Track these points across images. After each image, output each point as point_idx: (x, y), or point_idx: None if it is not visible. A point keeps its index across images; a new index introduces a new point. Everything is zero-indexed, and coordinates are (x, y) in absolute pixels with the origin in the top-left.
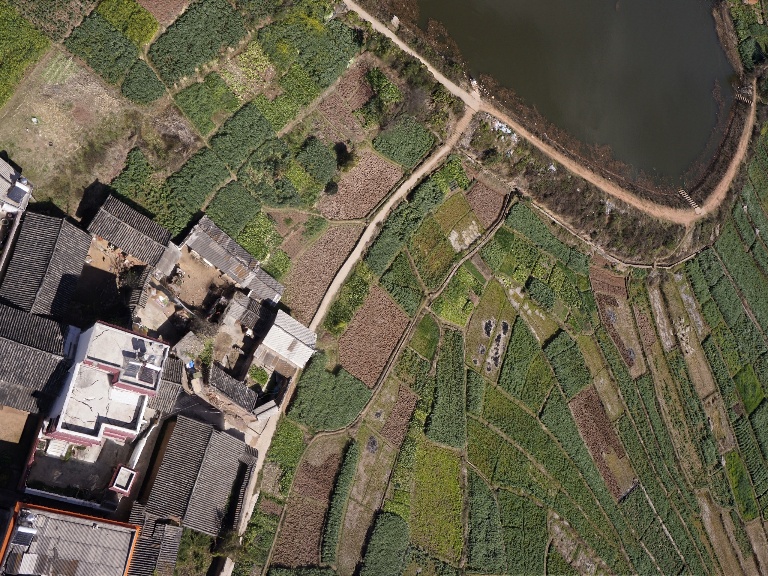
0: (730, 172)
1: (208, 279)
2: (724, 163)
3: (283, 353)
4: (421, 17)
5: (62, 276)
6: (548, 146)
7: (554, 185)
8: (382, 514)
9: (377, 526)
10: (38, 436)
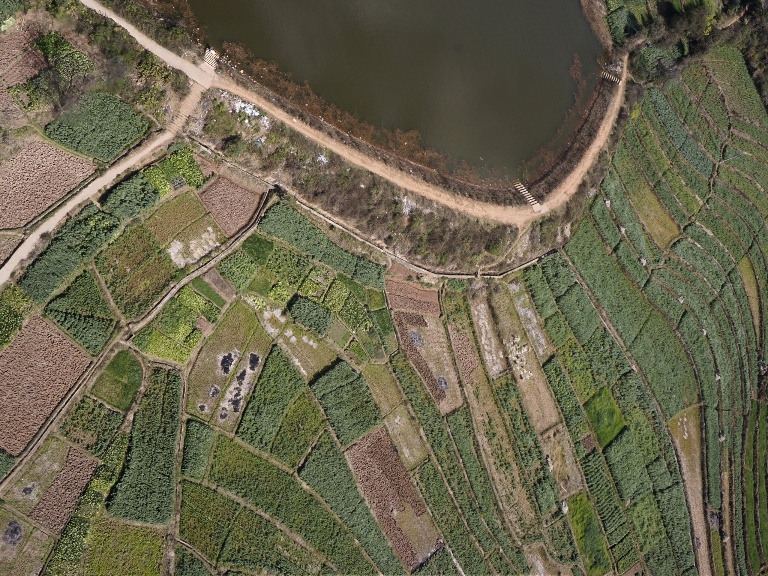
0: (585, 161)
1: None
2: (578, 151)
3: None
4: None
5: None
6: (318, 132)
7: (327, 180)
8: None
9: None
10: None
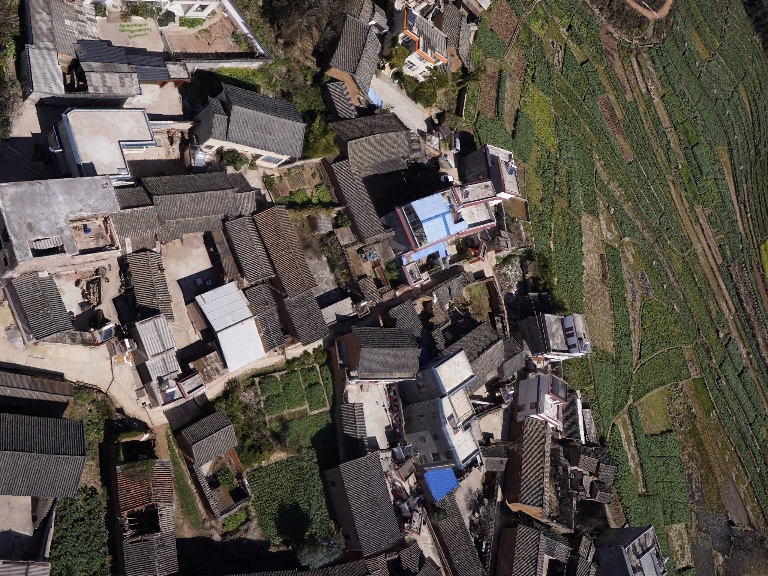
0: (669, 0)
1: None
2: None
3: None
4: None
5: None
6: None
7: None
8: None
9: (520, 115)
10: None
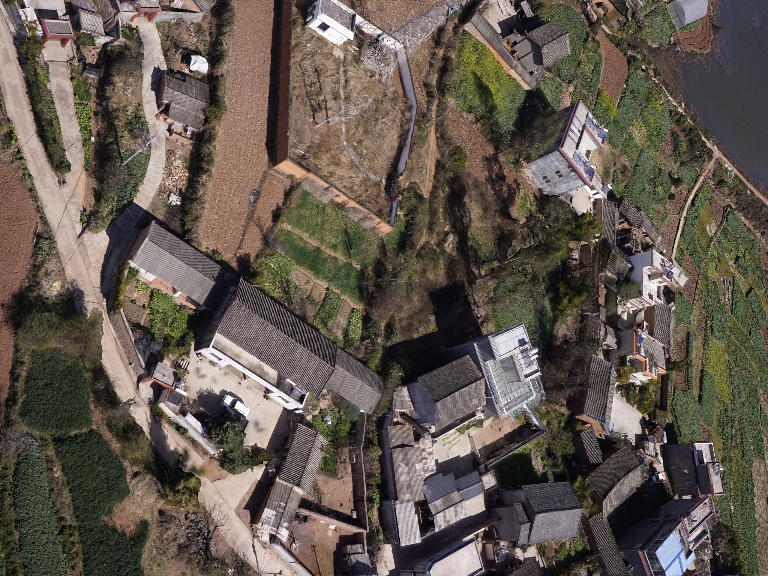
0: None
1: (640, 239)
2: None
3: (676, 278)
4: (687, 102)
5: (616, 230)
6: (745, 179)
7: (748, 202)
8: (705, 371)
9: (704, 377)
10: (617, 302)
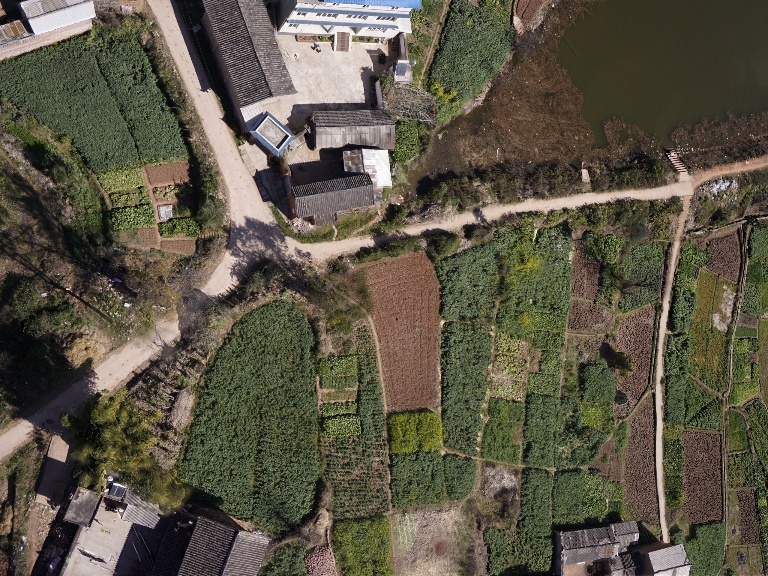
0: None
1: (583, 566)
2: None
3: None
4: (596, 133)
5: None
6: (764, 156)
7: None
8: None
9: None
10: None
